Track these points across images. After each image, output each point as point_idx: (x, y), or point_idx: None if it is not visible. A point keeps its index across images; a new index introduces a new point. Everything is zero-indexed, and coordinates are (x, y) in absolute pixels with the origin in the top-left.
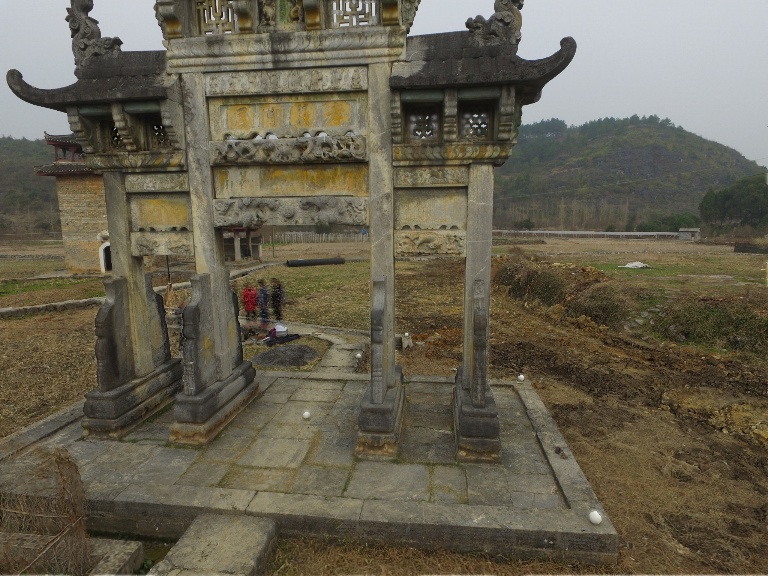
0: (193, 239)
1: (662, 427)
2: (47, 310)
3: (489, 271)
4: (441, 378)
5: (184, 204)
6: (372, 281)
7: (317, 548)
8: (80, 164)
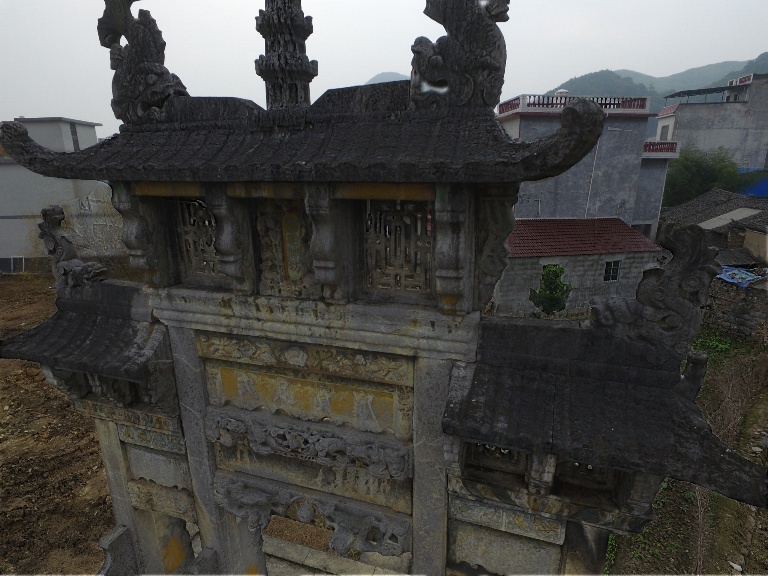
0: None
1: None
2: None
3: None
4: None
5: None
6: None
7: None
8: None
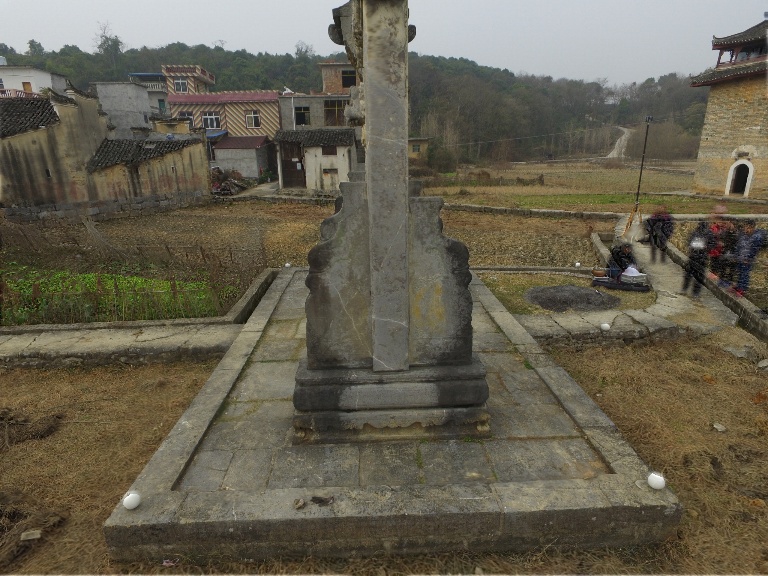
0: None
1: None
2: (576, 216)
3: (370, 185)
4: (569, 390)
5: None
6: None
7: None
8: (739, 67)
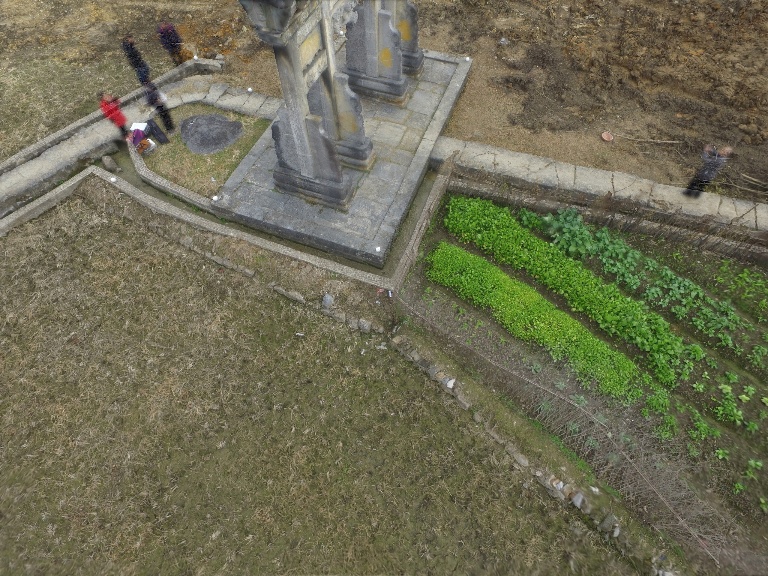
0: (327, 54)
1: None
2: None
3: None
4: None
5: (317, 31)
6: (377, 17)
7: (448, 131)
8: None
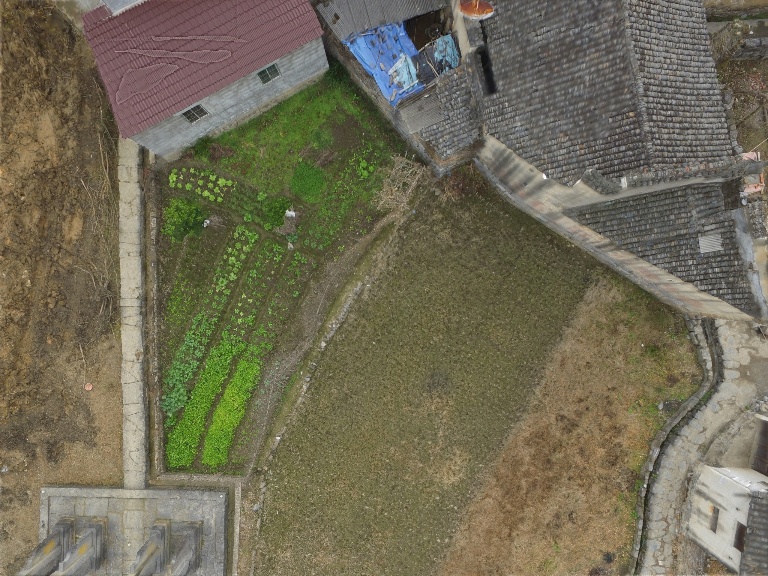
0: None
1: (0, 559)
2: None
3: None
4: None
5: None
6: (66, 571)
7: (116, 483)
8: None
